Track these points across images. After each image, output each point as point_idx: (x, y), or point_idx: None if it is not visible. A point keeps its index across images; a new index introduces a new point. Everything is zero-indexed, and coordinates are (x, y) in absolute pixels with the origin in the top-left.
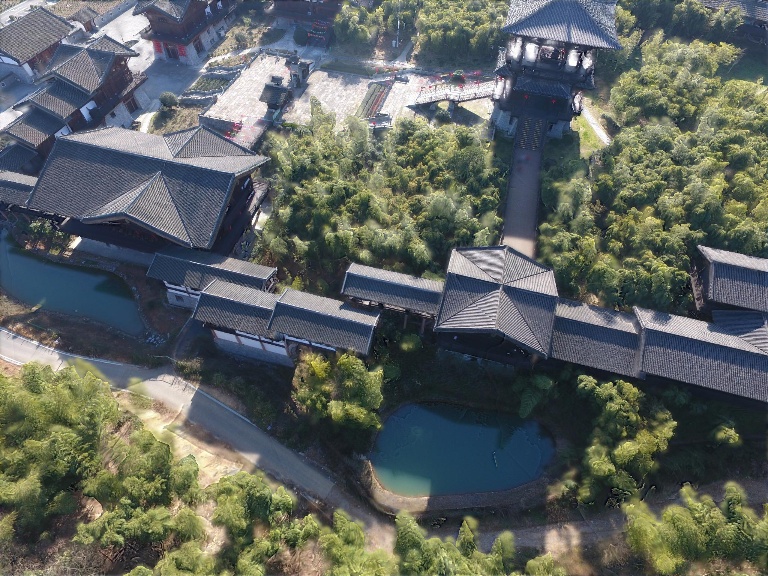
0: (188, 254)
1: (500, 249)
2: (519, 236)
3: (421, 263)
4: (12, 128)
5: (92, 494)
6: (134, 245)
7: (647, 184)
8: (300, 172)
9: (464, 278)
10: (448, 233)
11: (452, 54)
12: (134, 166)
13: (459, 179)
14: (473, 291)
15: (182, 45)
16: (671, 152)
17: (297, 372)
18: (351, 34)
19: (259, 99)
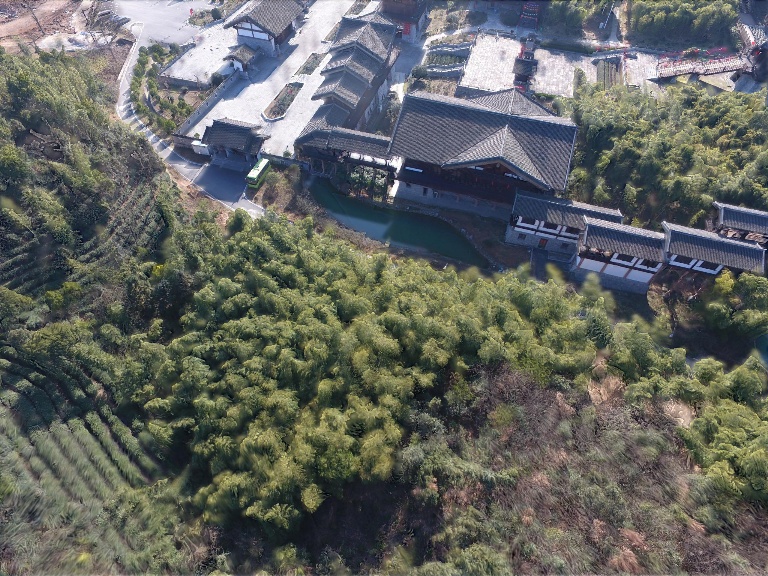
0: (539, 196)
1: None
2: None
3: (766, 204)
4: (335, 89)
5: (626, 364)
6: (471, 191)
7: None
8: (605, 131)
9: None
10: None
11: (662, 35)
12: (481, 120)
13: None
14: None
15: (412, 24)
16: None
17: (649, 298)
18: (571, 15)
19: (512, 71)
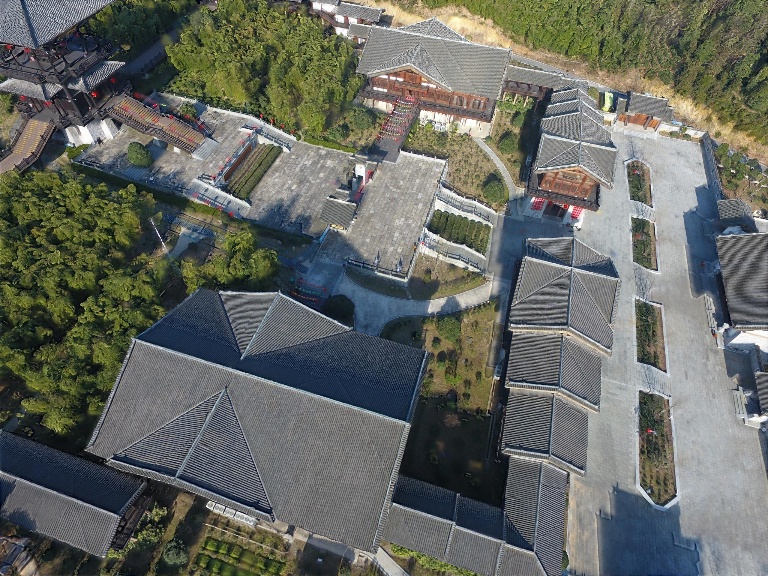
0: None
1: None
2: None
3: None
4: None
5: None
6: None
7: None
8: None
9: None
10: None
11: None
12: None
13: None
14: None
15: None
16: None
17: None
18: None
19: None
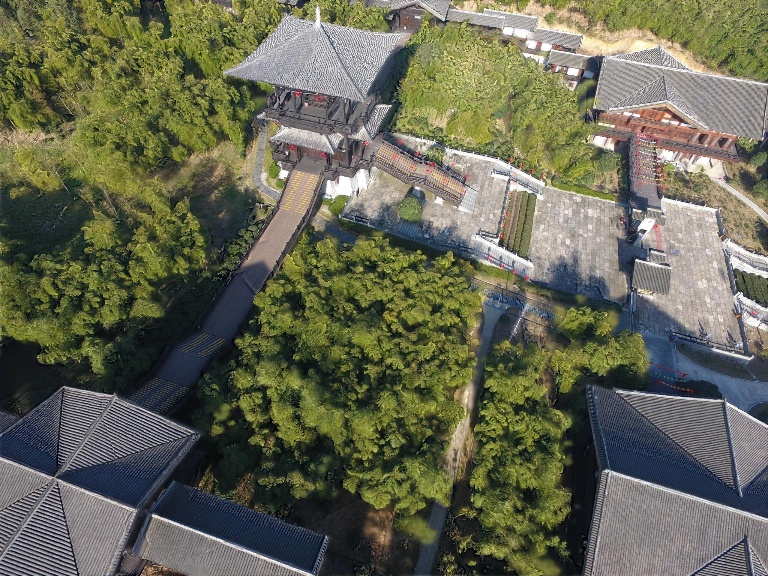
0: None
1: None
2: None
3: None
4: None
5: None
6: None
7: None
8: None
9: None
10: None
11: None
12: None
13: None
14: None
15: None
16: None
17: None
18: None
19: None
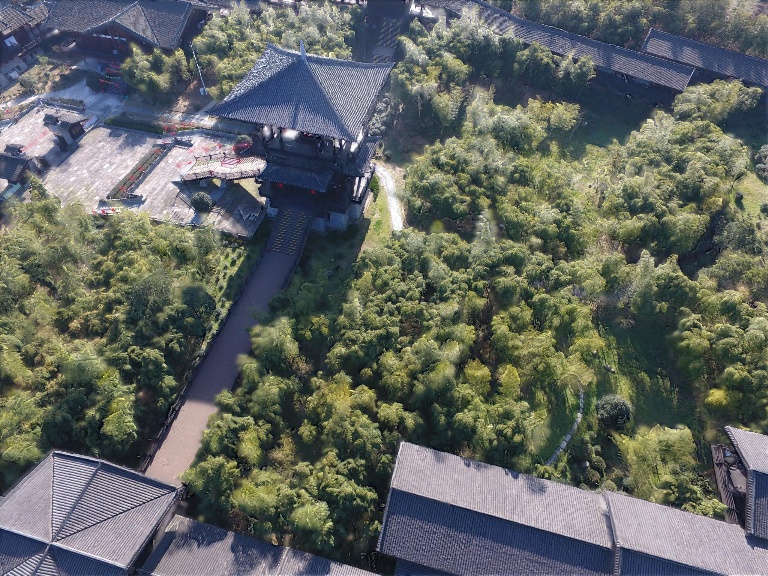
0: None
1: (93, 466)
2: (208, 399)
3: (25, 463)
4: None
5: None
6: None
7: (367, 335)
8: None
9: (1, 530)
10: (89, 407)
11: None
12: None
13: (134, 319)
14: (9, 553)
15: None
16: (427, 276)
17: None
18: (138, 83)
19: None
